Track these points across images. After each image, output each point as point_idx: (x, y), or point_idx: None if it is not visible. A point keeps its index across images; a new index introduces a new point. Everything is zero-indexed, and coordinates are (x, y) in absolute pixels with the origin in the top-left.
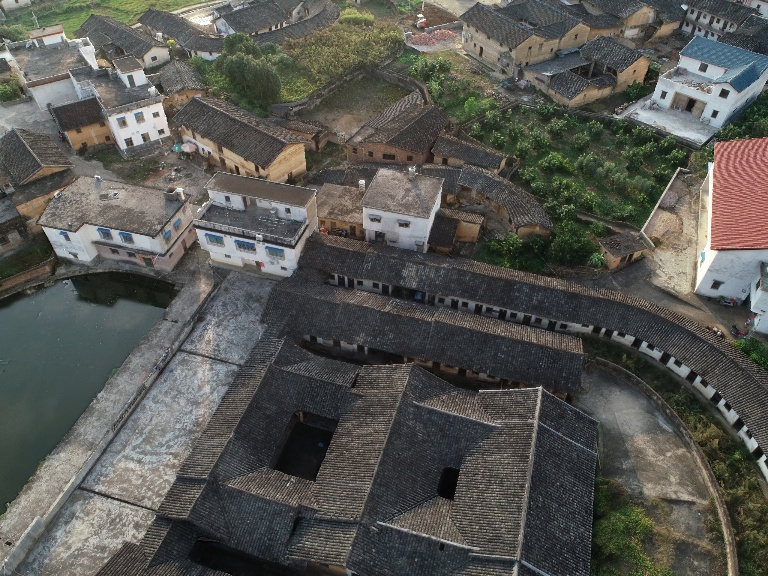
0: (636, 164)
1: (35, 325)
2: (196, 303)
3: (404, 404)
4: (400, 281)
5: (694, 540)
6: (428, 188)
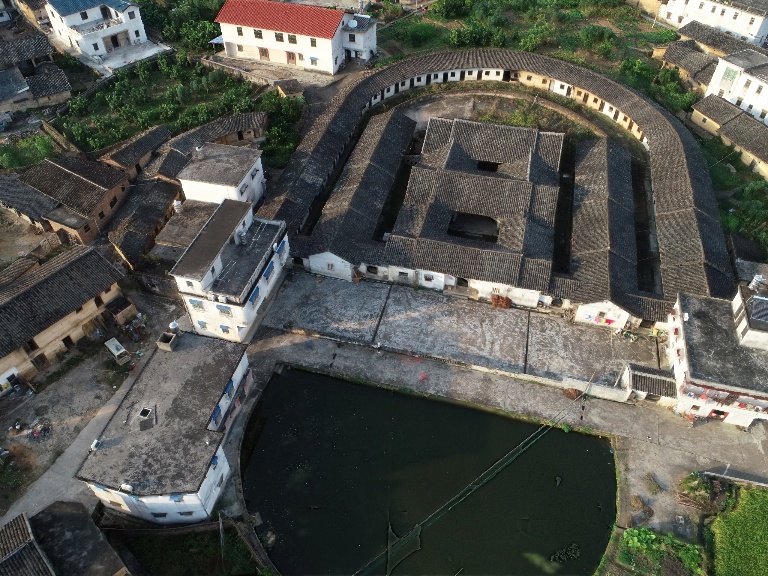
0: (187, 75)
1: (334, 504)
2: (308, 344)
3: None
4: (316, 186)
5: None
6: (219, 150)
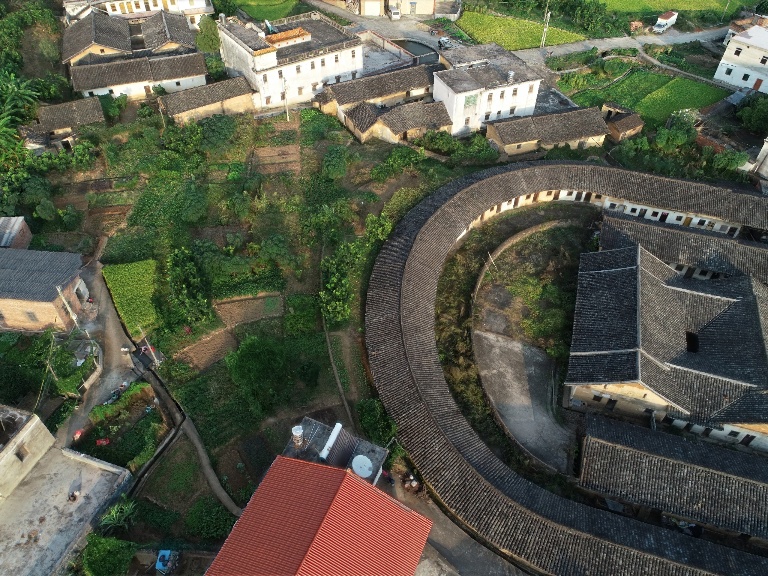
0: None
1: None
2: None
3: (766, 380)
4: None
5: (494, 310)
6: None
